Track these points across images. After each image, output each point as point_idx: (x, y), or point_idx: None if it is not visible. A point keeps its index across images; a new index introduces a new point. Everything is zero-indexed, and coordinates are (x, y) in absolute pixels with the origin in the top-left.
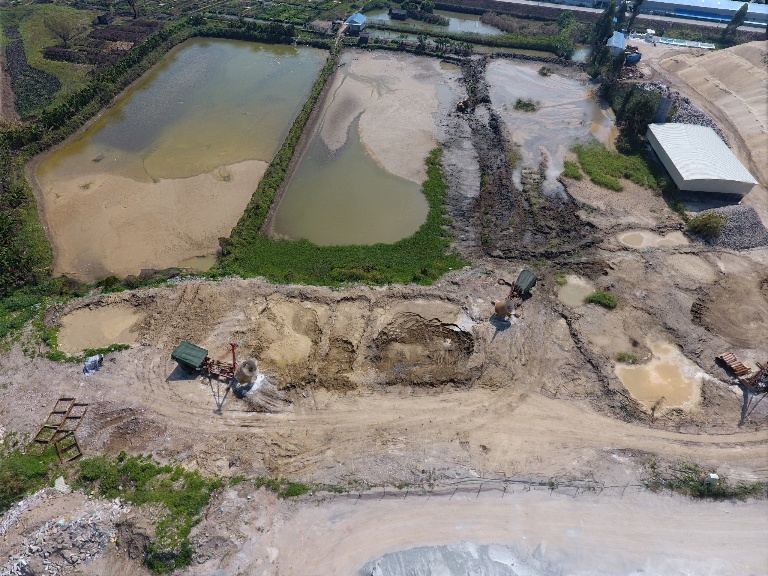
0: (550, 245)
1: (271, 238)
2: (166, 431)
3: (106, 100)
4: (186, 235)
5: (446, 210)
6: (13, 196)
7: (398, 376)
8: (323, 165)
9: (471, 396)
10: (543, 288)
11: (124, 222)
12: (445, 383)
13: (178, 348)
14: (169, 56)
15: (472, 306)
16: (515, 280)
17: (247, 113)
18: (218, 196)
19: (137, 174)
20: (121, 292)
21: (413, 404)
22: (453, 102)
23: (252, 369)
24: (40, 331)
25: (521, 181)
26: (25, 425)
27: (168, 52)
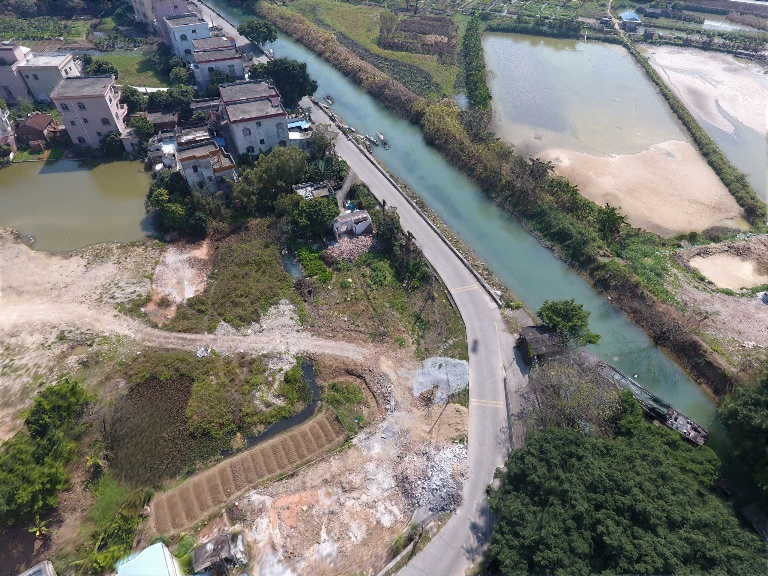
0: None
1: None
2: None
3: None
4: (697, 201)
5: None
6: None
7: None
8: (738, 145)
9: None
10: None
11: (629, 190)
12: None
13: None
14: (484, 48)
15: None
16: None
17: (617, 100)
18: (682, 170)
19: (588, 150)
20: (710, 245)
21: None
22: None
23: None
24: (688, 273)
25: None
26: None
27: None
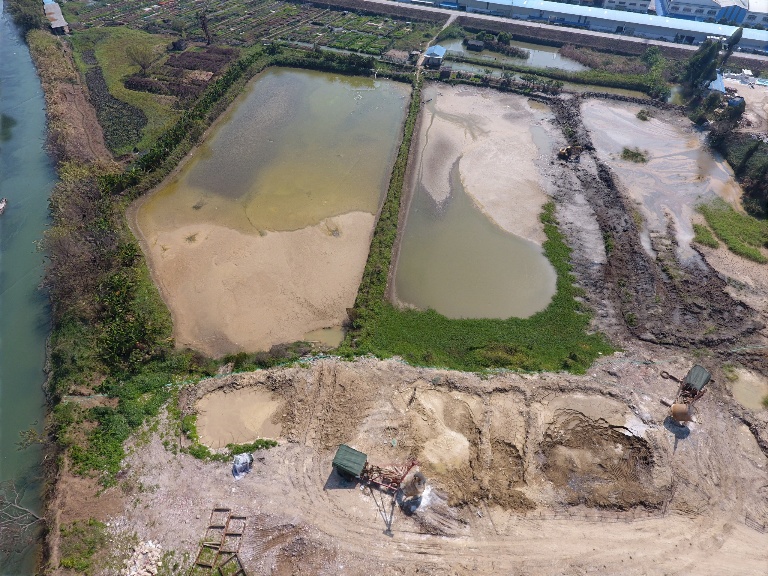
0: (707, 330)
1: (396, 307)
2: (336, 556)
3: (196, 138)
4: (306, 301)
5: (575, 278)
6: (126, 253)
7: (580, 495)
8: (433, 219)
9: (668, 525)
10: (714, 385)
11: (238, 283)
12: (635, 506)
13: (338, 453)
14: (249, 87)
15: (640, 405)
16: (679, 373)
17: (341, 155)
18: (331, 254)
19: (241, 225)
20: (253, 372)
21: (605, 533)
22: (552, 147)
23: (420, 481)
24: (177, 419)
25: (652, 247)
26: (182, 542)
27: (248, 83)
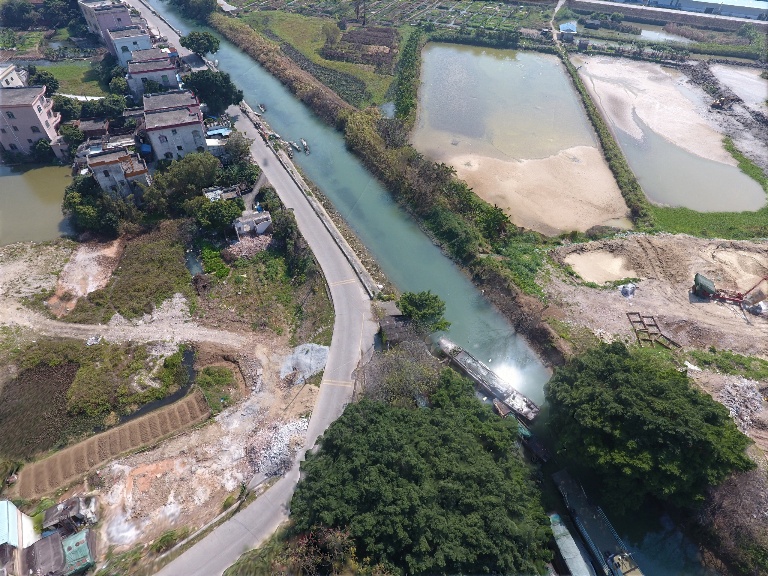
0: None
1: (657, 206)
2: (725, 335)
3: (416, 95)
4: (589, 202)
5: None
6: None
7: None
8: (643, 150)
9: None
10: None
11: (528, 192)
12: None
13: (699, 278)
14: (424, 58)
15: None
16: None
17: (539, 107)
18: (583, 173)
19: (499, 155)
20: (589, 242)
21: None
22: (702, 101)
23: None
24: (560, 268)
25: None
26: (620, 330)
27: (421, 55)
